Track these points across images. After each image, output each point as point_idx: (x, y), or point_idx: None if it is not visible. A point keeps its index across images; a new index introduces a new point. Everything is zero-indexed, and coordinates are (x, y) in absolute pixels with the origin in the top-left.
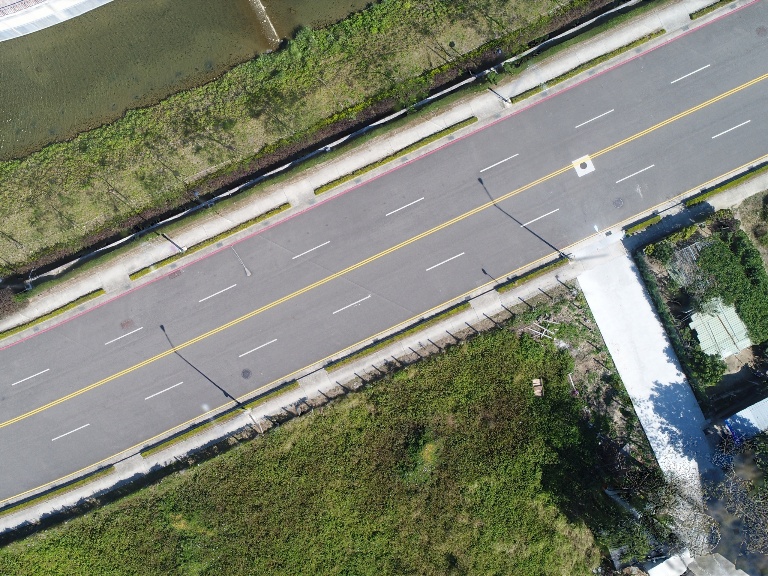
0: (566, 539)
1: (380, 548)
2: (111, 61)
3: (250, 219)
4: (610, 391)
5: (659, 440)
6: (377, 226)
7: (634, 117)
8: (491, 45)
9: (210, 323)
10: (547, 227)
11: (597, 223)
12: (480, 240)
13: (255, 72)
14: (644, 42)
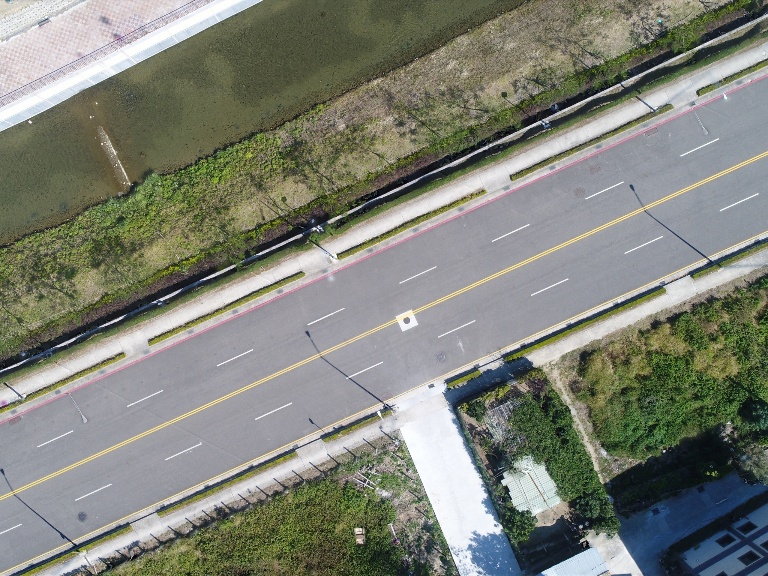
0: None
1: None
2: None
3: (87, 368)
4: (431, 540)
5: None
6: (208, 376)
7: (456, 274)
8: (320, 201)
9: (48, 468)
10: (372, 379)
11: (420, 376)
12: (307, 391)
13: (102, 218)
14: (466, 202)
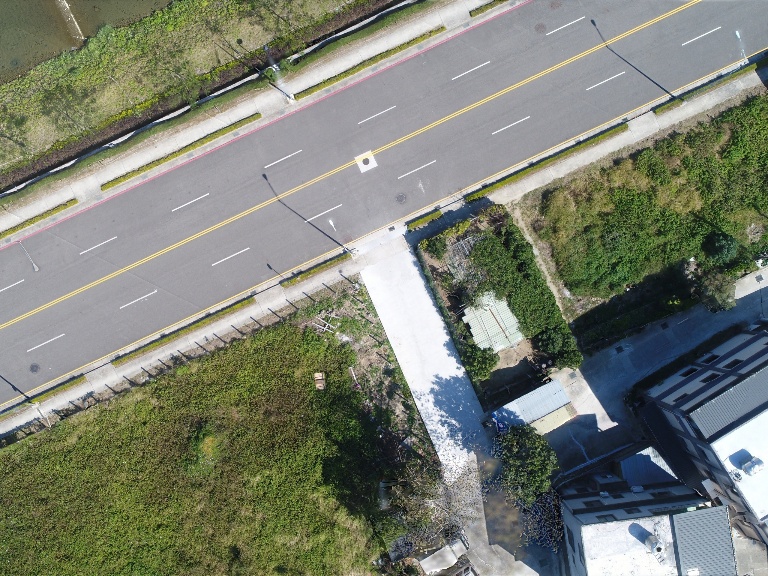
0: (347, 531)
1: (164, 540)
2: None
3: (38, 215)
4: (392, 385)
5: (439, 433)
6: (163, 222)
7: (415, 113)
8: (277, 42)
9: None
10: None
11: (380, 218)
12: (265, 235)
13: (54, 69)
14: (425, 39)
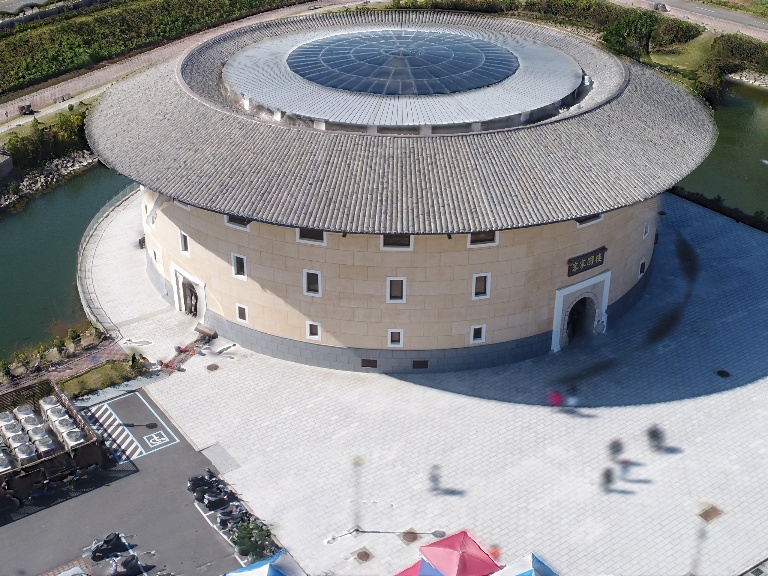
0: None
1: None
2: None
3: (59, 2)
4: None
5: None
6: None
7: None
8: None
9: None
10: None
11: None
12: None
13: None
14: None
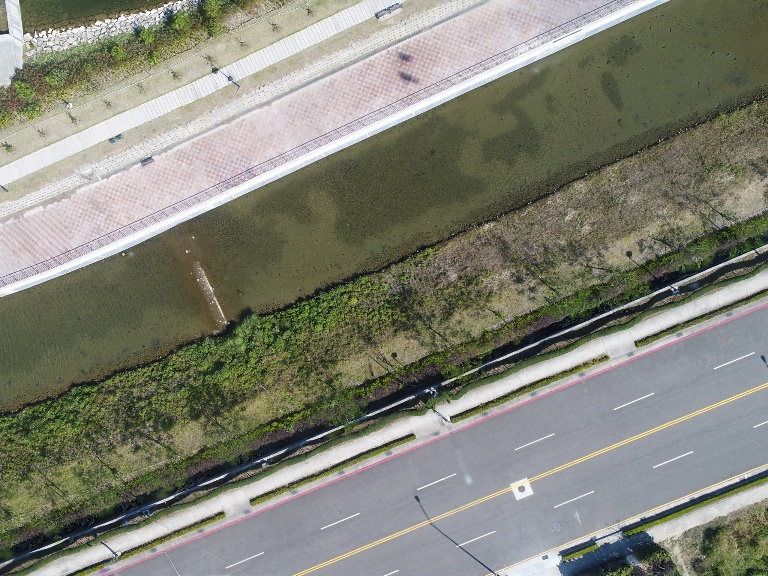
0: None
1: None
2: (59, 334)
3: (185, 526)
4: None
5: None
6: (312, 540)
7: (575, 442)
8: (433, 359)
9: None
10: (483, 548)
11: (534, 547)
12: (415, 558)
13: (199, 361)
14: (587, 368)
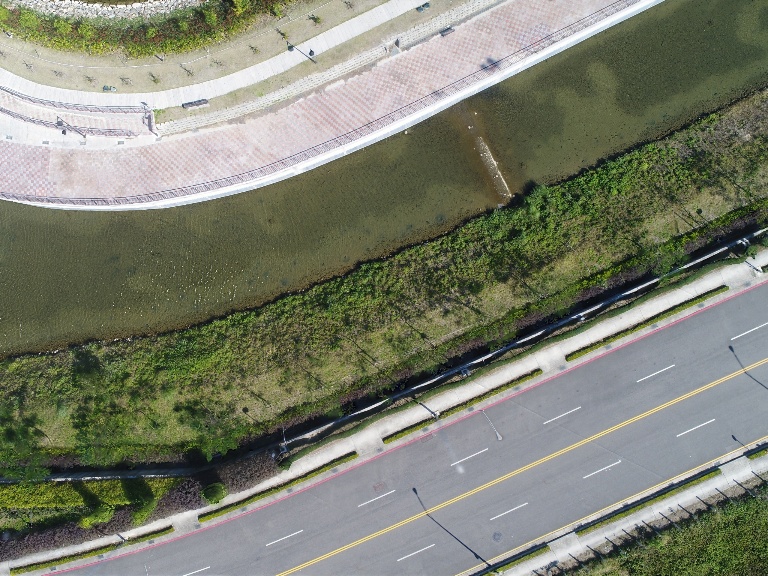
0: None
1: None
2: (343, 213)
3: (502, 384)
4: None
5: None
6: (628, 392)
7: None
8: (740, 213)
9: (462, 486)
10: None
11: None
12: (730, 407)
13: (493, 230)
14: None
